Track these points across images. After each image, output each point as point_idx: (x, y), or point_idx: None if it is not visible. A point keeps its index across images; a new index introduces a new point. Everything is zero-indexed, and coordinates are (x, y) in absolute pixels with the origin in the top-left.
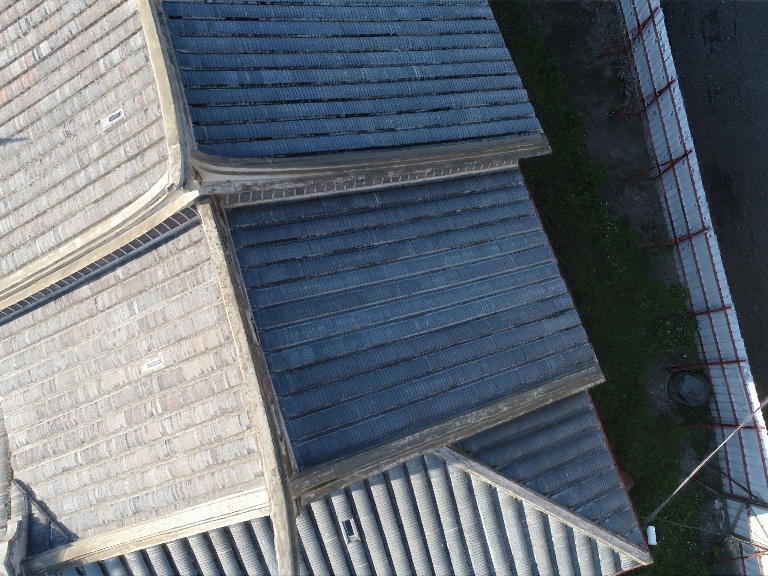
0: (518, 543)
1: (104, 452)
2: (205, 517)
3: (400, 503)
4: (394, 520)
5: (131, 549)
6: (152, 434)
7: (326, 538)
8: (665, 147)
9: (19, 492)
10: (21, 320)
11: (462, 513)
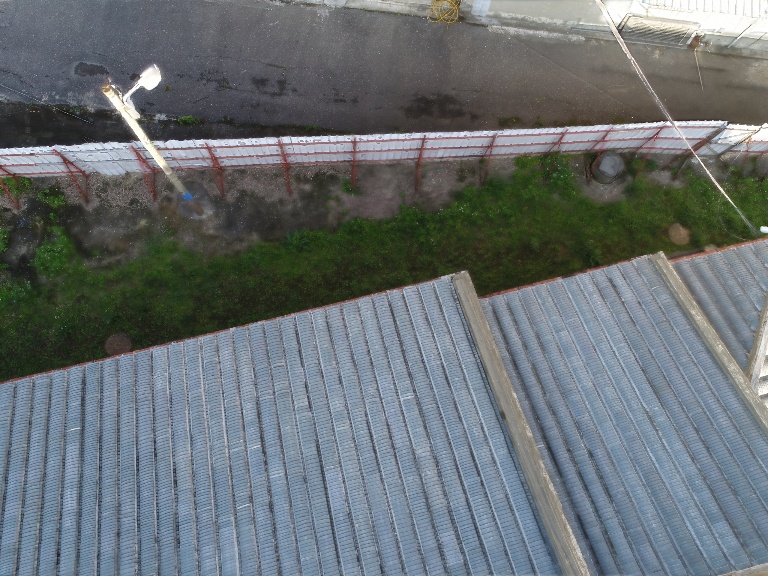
0: None
1: None
2: None
3: None
4: None
5: None
6: None
7: None
8: (400, 152)
9: None
10: None
11: None
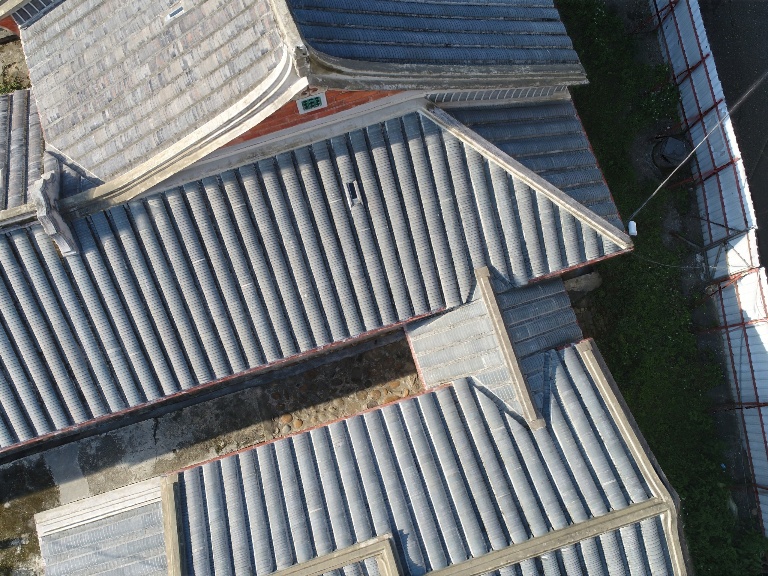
0: (508, 217)
1: (130, 102)
2: (223, 121)
3: (399, 168)
4: (394, 185)
5: (155, 181)
6: (174, 71)
7: (332, 199)
8: None
9: (51, 157)
10: (52, 13)
11: (456, 183)
